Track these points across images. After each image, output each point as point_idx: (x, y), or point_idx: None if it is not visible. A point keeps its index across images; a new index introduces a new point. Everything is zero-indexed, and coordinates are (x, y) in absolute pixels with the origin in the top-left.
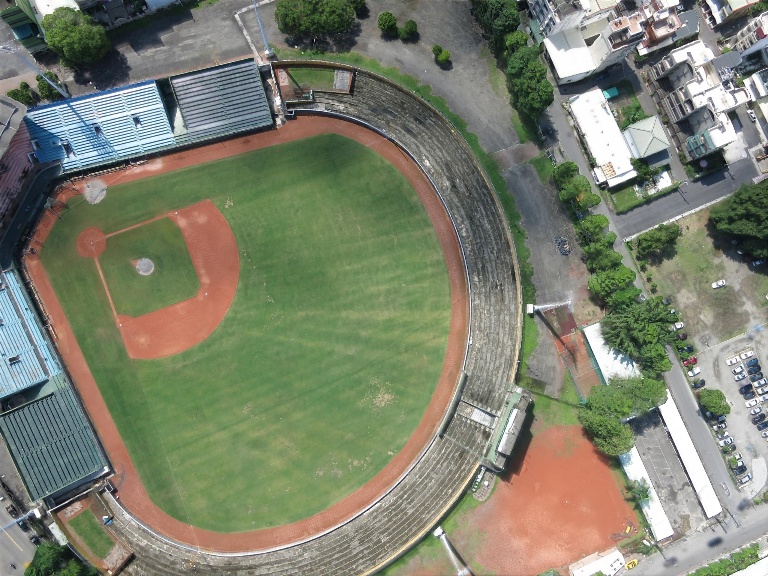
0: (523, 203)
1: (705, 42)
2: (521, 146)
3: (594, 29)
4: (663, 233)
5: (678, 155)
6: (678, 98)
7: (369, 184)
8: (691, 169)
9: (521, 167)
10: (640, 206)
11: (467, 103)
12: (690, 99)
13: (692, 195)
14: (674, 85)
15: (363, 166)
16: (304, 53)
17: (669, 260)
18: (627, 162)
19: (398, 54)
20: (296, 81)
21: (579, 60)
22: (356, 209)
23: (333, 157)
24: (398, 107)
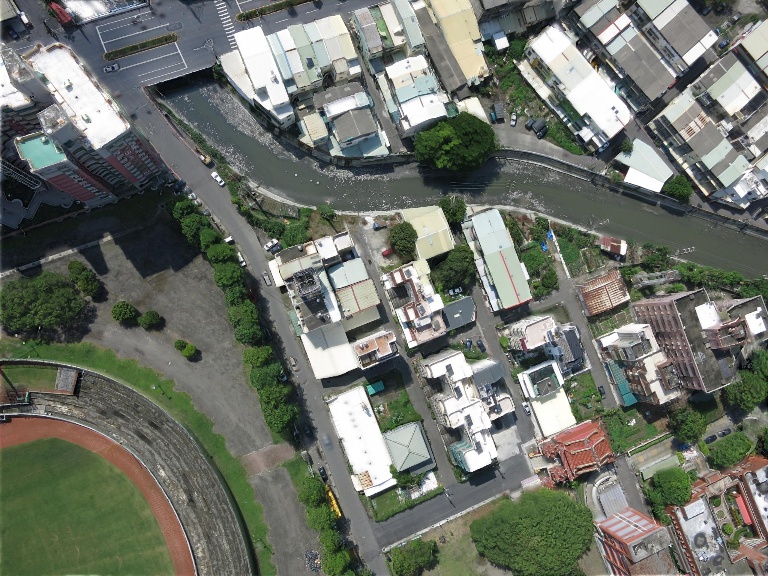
0: (272, 513)
1: (483, 327)
2: (274, 447)
3: (361, 318)
4: (412, 562)
5: (446, 454)
6: (439, 408)
7: (93, 497)
8: (457, 472)
9: (273, 471)
10: (402, 511)
11: (215, 399)
12: (447, 416)
13: (459, 497)
14: (442, 384)
15: (88, 476)
16: (25, 343)
17: (430, 570)
18: (386, 470)
19: (139, 343)
20: (10, 381)
21: (337, 361)
22: (76, 527)
23: (52, 466)
24: (131, 410)
